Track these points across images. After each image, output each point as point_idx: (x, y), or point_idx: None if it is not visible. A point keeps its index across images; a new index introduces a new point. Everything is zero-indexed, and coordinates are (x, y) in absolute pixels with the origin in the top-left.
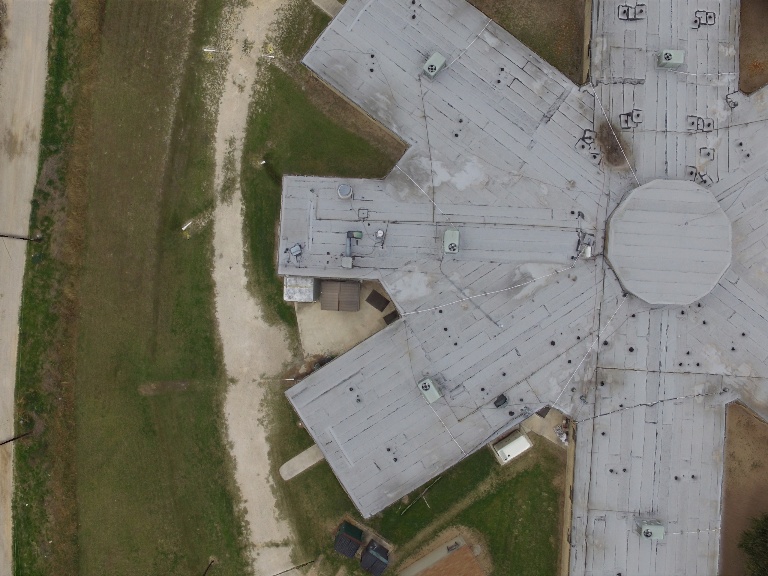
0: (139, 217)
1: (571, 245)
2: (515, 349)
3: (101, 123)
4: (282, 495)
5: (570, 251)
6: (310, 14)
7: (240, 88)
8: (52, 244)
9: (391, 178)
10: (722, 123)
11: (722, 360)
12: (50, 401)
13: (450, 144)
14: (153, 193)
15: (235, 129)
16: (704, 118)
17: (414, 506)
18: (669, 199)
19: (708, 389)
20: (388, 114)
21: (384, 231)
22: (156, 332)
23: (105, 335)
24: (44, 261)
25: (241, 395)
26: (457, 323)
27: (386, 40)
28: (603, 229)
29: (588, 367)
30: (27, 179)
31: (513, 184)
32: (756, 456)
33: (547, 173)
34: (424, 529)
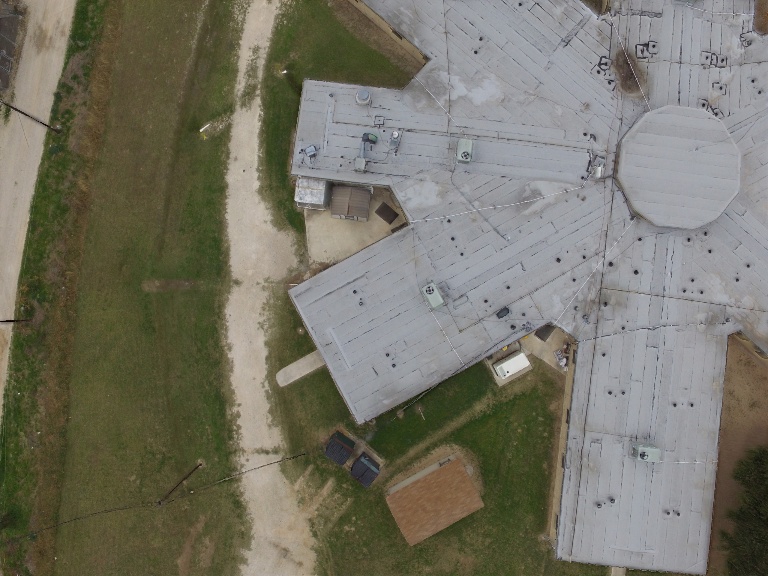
0: (158, 116)
1: (582, 165)
2: (520, 263)
3: (130, 24)
4: (277, 401)
5: (580, 171)
6: None
7: None
8: (71, 136)
9: (409, 89)
10: (735, 60)
11: (726, 291)
12: (53, 290)
13: (469, 60)
14: (174, 94)
15: (260, 38)
16: (718, 54)
17: (409, 421)
18: (680, 125)
19: (711, 319)
20: (410, 28)
21: (399, 138)
22: (165, 229)
23: (114, 228)
24: (61, 152)
25: (244, 297)
26: (464, 234)
27: None
28: (614, 152)
29: (592, 287)
30: (52, 72)
31: (528, 103)
32: (756, 397)
33: (562, 95)
34: (417, 446)
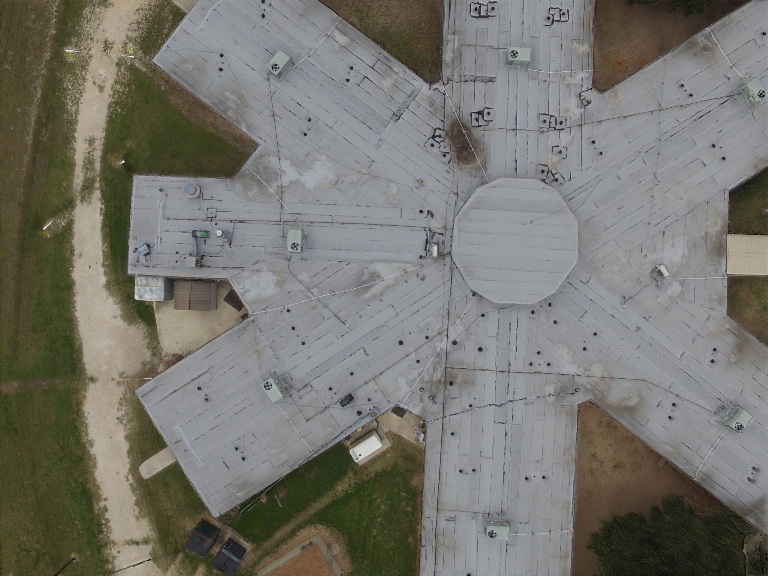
0: (0, 217)
1: (419, 244)
2: (363, 349)
3: None
4: (142, 493)
5: (418, 250)
6: (170, 14)
7: (100, 88)
8: None
9: (240, 177)
10: (575, 121)
11: (574, 360)
12: None
13: (299, 143)
14: (14, 193)
15: (95, 129)
16: (556, 116)
17: (272, 505)
18: (514, 198)
19: (560, 389)
20: (237, 113)
21: (231, 230)
22: (18, 331)
23: None
24: None
25: (100, 394)
26: (305, 322)
27: (235, 39)
28: (451, 228)
29: (437, 367)
30: None
31: (362, 183)
32: (618, 457)
33: (396, 172)
34: (282, 528)
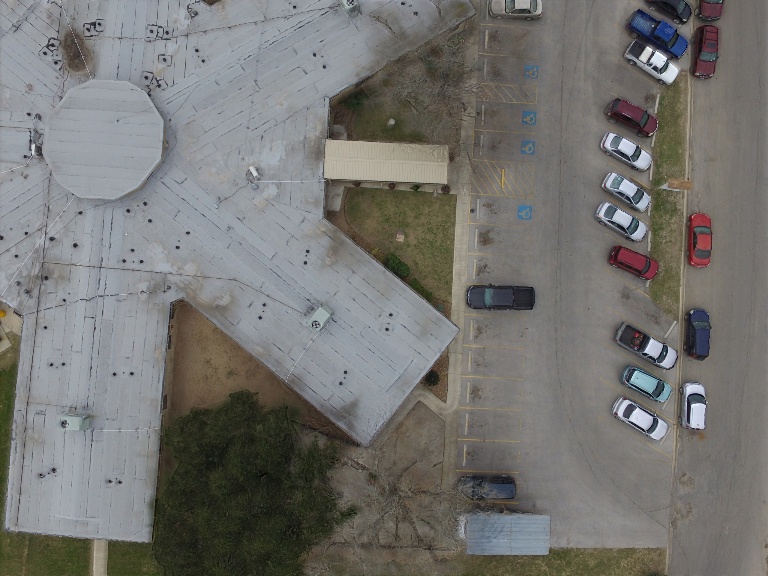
0: None
1: (24, 144)
2: None
3: None
4: None
5: (24, 150)
6: None
7: None
8: None
9: None
10: (182, 31)
11: (169, 259)
12: None
13: None
14: None
15: None
16: (164, 27)
17: None
18: (103, 98)
19: (153, 287)
20: None
21: None
22: None
23: None
24: None
25: None
26: None
27: None
28: None
29: (35, 262)
30: None
31: None
32: (233, 364)
33: (8, 78)
34: None
